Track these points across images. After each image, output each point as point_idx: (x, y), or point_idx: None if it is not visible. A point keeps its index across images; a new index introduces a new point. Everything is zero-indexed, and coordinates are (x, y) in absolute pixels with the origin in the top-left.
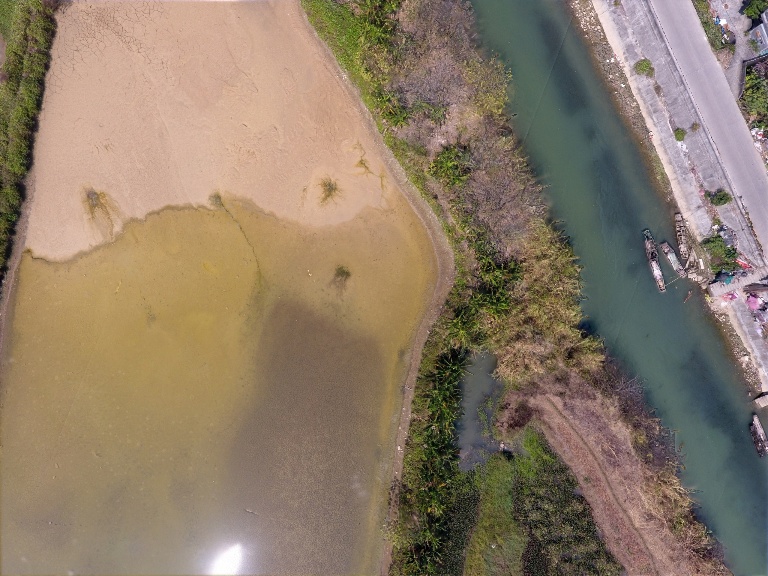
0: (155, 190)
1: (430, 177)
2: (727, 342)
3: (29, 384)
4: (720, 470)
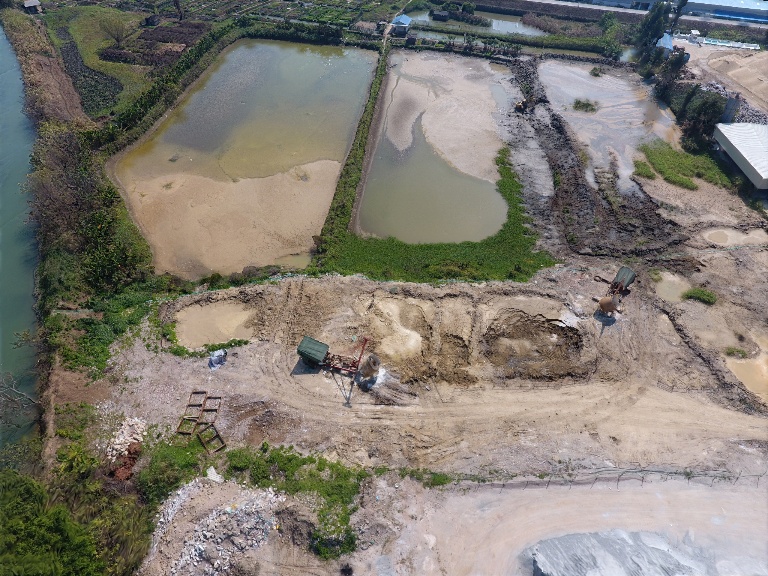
0: None
1: None
2: None
3: None
4: None
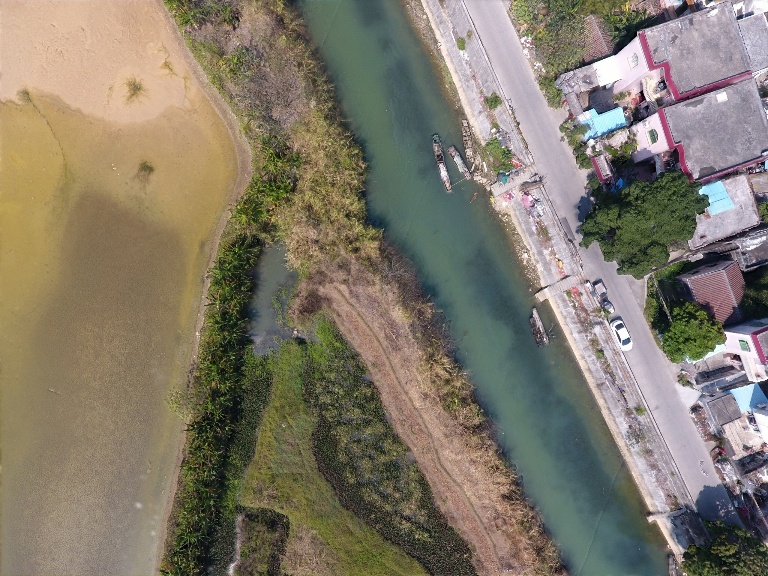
0: None
1: None
2: (510, 241)
3: None
4: (502, 359)
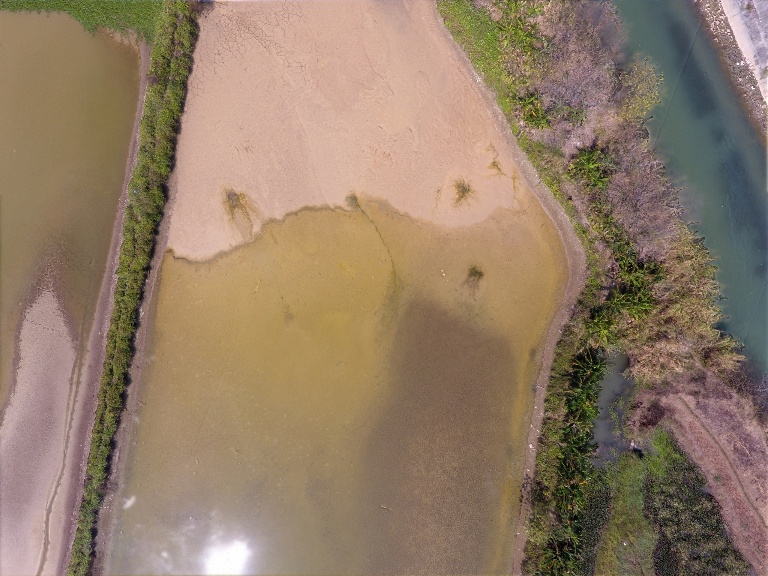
0: (293, 191)
1: (565, 179)
2: None
3: (171, 381)
4: None
